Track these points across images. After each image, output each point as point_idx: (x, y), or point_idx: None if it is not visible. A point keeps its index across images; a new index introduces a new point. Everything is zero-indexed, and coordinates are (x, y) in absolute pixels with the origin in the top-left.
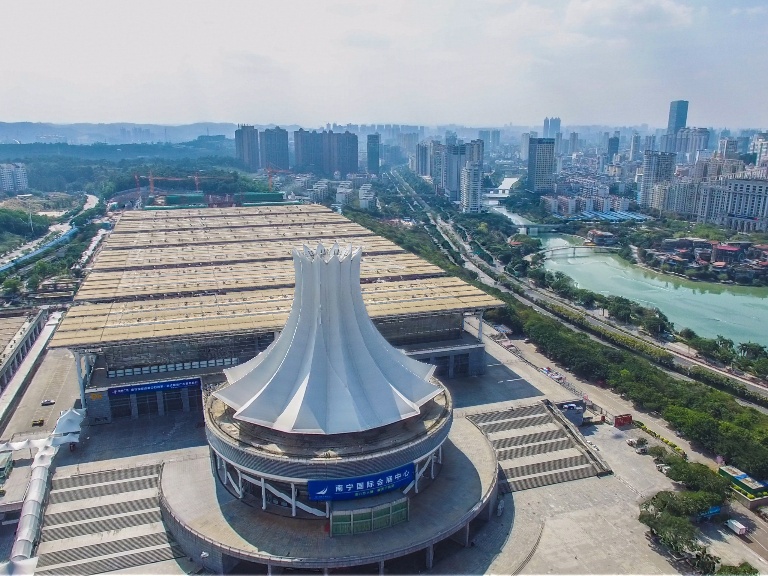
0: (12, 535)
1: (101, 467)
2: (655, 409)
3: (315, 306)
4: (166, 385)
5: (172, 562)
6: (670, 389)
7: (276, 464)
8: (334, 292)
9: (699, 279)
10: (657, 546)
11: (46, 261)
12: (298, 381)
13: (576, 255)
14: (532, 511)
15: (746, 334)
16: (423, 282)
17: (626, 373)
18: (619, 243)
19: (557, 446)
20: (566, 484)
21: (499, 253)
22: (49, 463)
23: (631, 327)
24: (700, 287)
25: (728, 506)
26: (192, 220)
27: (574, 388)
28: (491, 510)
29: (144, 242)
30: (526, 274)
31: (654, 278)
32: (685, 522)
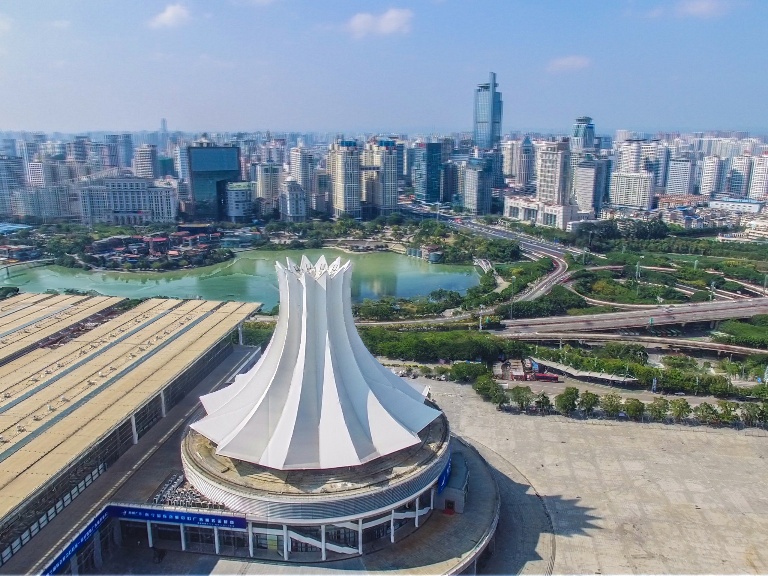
0: None
1: None
2: None
3: (339, 324)
4: (80, 541)
5: None
6: None
7: (420, 479)
8: (349, 304)
9: (166, 269)
10: (511, 412)
11: None
12: (355, 405)
13: (11, 275)
14: None
15: (262, 299)
16: (141, 311)
17: None
18: (46, 254)
19: None
20: None
21: None
22: None
23: None
24: (167, 277)
25: None
26: None
27: None
28: None
29: None
30: None
31: (118, 279)
32: None
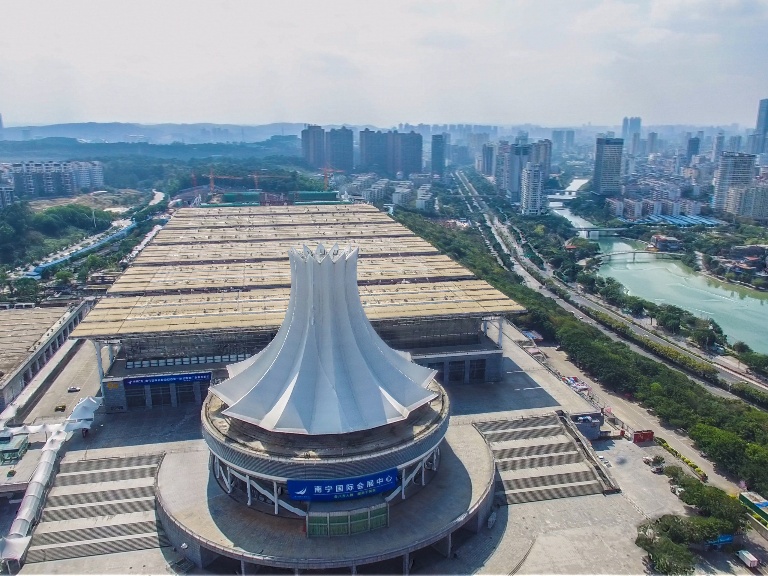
0: (14, 514)
1: (107, 454)
2: (682, 426)
3: (308, 306)
4: (179, 378)
5: (157, 551)
6: (703, 406)
7: (257, 461)
8: (327, 292)
9: (767, 289)
10: (653, 572)
11: (100, 255)
12: (289, 380)
13: (636, 260)
14: (525, 526)
15: None
16: (447, 284)
17: (656, 386)
18: (684, 249)
19: (564, 459)
20: (568, 500)
21: (550, 257)
22: (58, 447)
23: (679, 338)
24: None
25: (742, 535)
26: (241, 218)
27: (598, 400)
28: (481, 522)
29: (189, 238)
30: (575, 279)
31: (718, 287)
32: (682, 549)
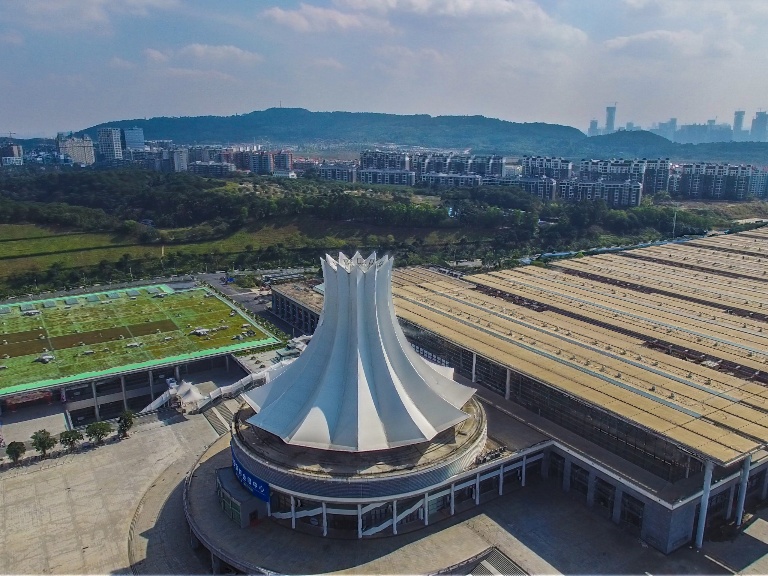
0: None
1: None
2: None
3: None
4: None
5: None
6: None
7: None
8: None
9: None
10: None
11: None
12: None
13: None
14: None
15: None
16: (748, 388)
17: None
18: None
19: None
20: None
21: None
22: None
23: None
24: None
25: None
26: None
27: None
28: None
29: (665, 255)
30: None
31: None
32: None
